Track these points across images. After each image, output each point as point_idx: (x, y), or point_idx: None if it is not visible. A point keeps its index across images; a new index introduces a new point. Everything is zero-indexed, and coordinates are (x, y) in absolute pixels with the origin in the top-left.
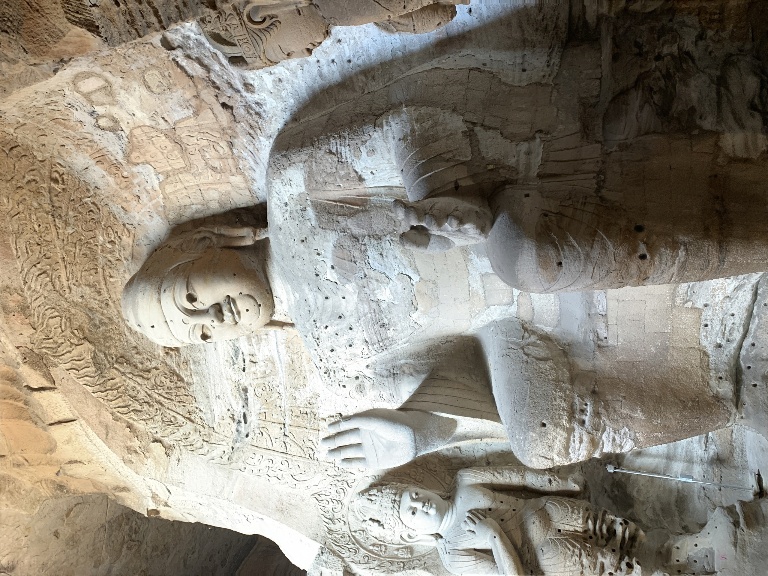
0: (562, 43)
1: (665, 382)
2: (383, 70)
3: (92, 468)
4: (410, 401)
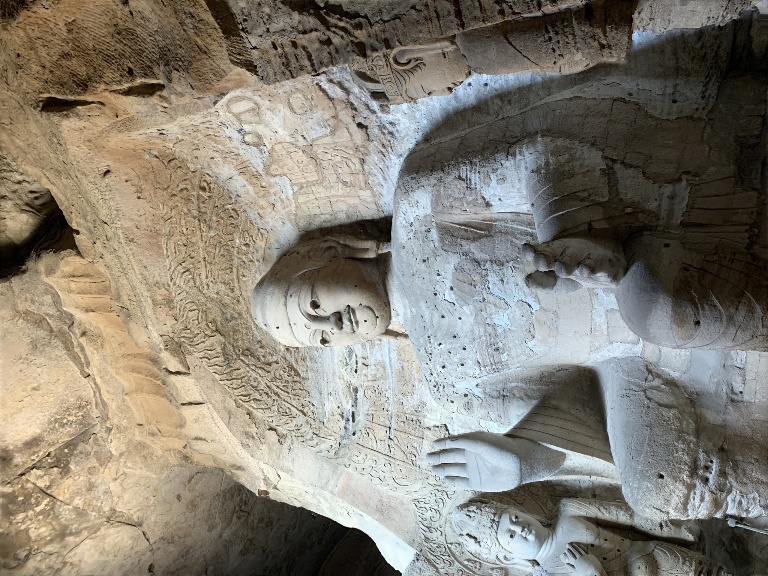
0: (721, 73)
1: None
2: (520, 95)
3: (214, 446)
4: (518, 428)
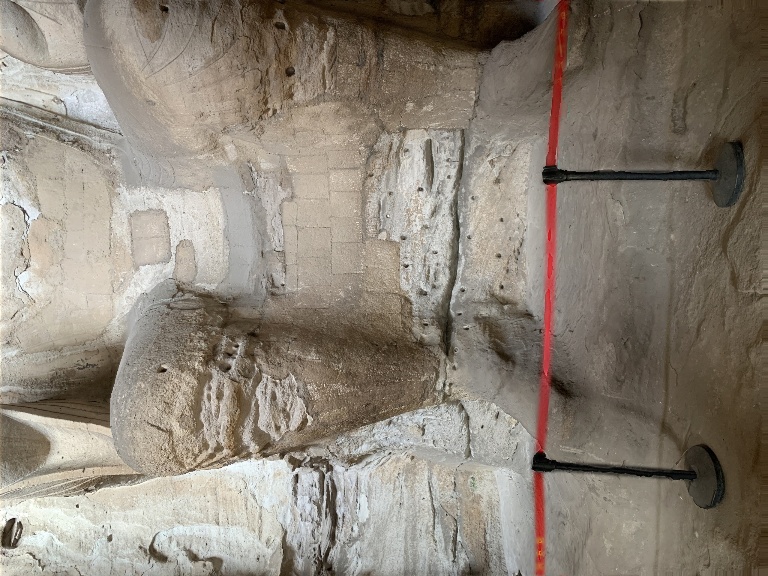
0: None
1: (354, 327)
2: None
3: None
4: None
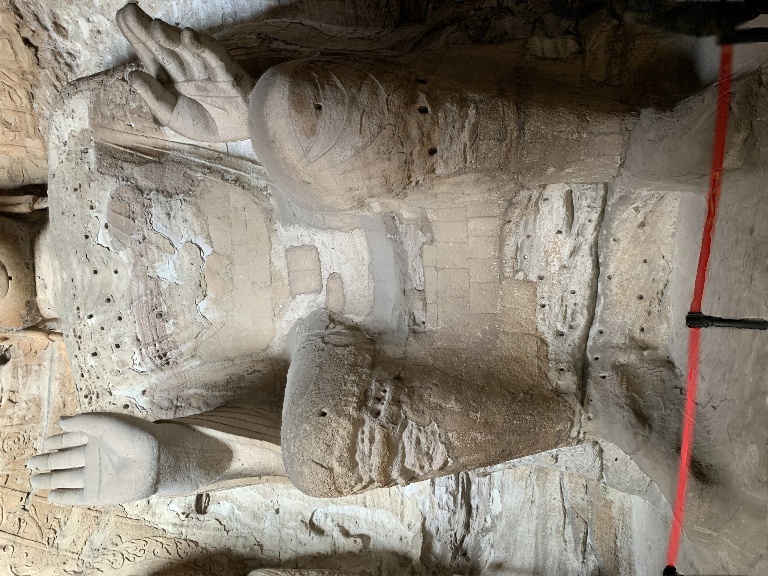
0: (395, 23)
1: (491, 371)
2: None
3: None
4: None
